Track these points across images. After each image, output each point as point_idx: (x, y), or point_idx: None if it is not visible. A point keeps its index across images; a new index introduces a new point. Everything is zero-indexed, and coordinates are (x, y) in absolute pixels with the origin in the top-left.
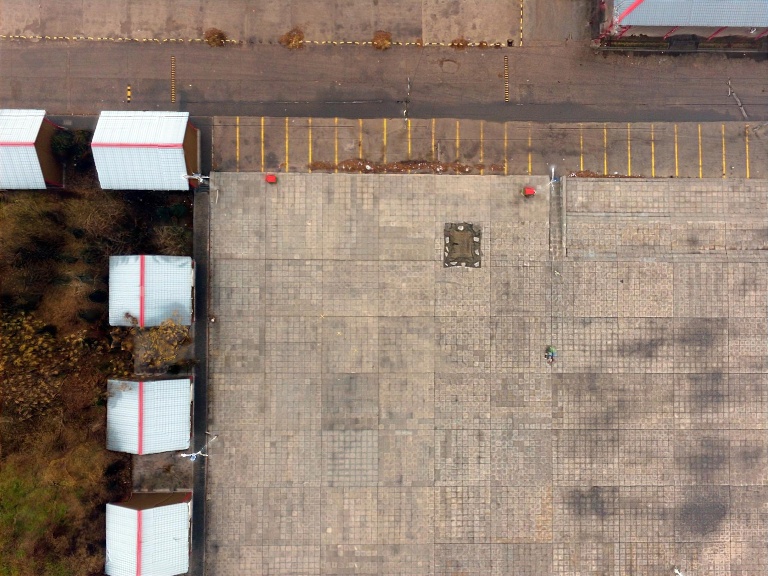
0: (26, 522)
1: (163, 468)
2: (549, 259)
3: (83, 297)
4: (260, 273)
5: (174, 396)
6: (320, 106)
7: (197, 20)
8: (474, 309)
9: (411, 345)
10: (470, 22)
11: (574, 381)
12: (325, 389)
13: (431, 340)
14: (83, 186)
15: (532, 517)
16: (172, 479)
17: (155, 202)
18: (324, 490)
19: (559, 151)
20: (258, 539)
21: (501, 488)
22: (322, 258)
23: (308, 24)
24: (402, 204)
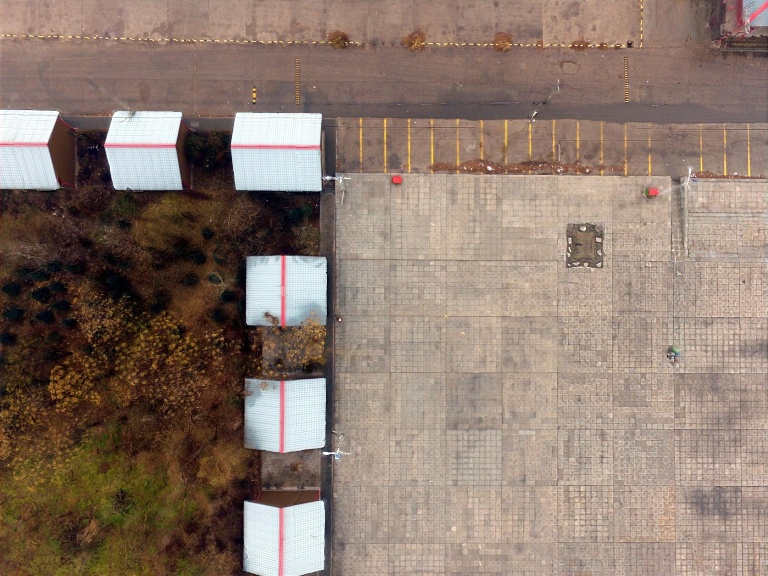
0: (157, 519)
1: (291, 466)
2: (671, 259)
3: (211, 297)
4: (385, 273)
5: (311, 395)
6: (442, 107)
7: (321, 22)
8: (596, 309)
9: (534, 345)
10: (590, 23)
11: (696, 381)
12: (449, 388)
13: (554, 340)
14: (211, 187)
15: (655, 517)
16: (300, 477)
17: (281, 203)
18: (448, 489)
19: (679, 152)
20: (384, 537)
21: (624, 488)
22: (446, 258)
23: (430, 26)
24: (525, 205)
